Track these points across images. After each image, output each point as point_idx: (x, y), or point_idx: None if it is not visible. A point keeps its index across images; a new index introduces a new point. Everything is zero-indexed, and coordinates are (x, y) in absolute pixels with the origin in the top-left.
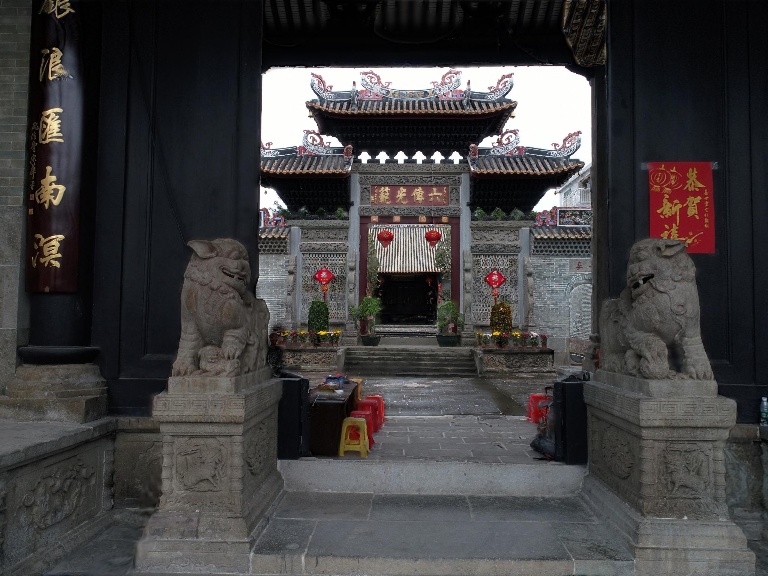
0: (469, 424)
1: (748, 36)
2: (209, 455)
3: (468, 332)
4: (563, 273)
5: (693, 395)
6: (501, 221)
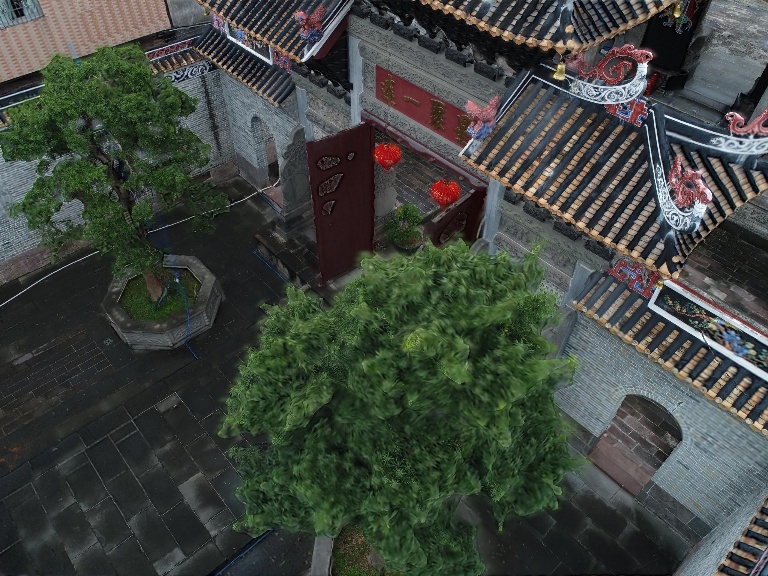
0: None
1: None
2: None
3: None
4: None
5: None
6: None
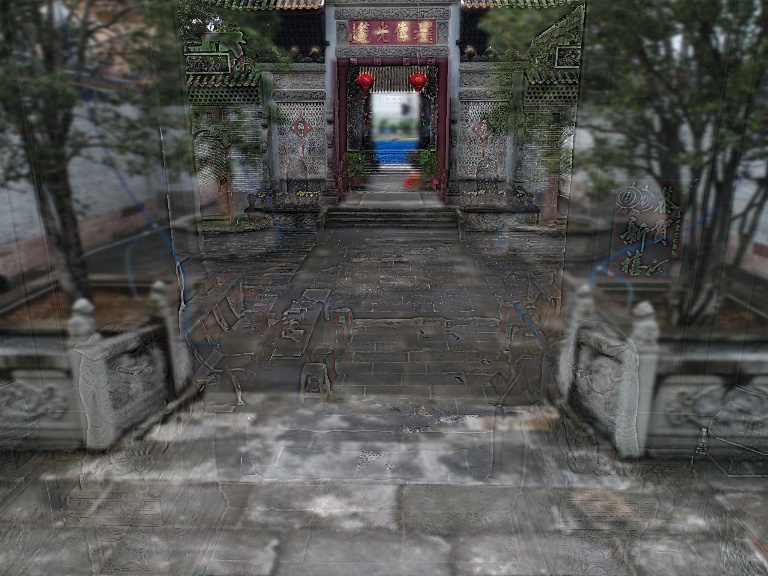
0: (437, 336)
1: (763, 15)
2: (132, 543)
3: (453, 189)
4: (557, 122)
5: (617, 490)
6: (493, 63)
